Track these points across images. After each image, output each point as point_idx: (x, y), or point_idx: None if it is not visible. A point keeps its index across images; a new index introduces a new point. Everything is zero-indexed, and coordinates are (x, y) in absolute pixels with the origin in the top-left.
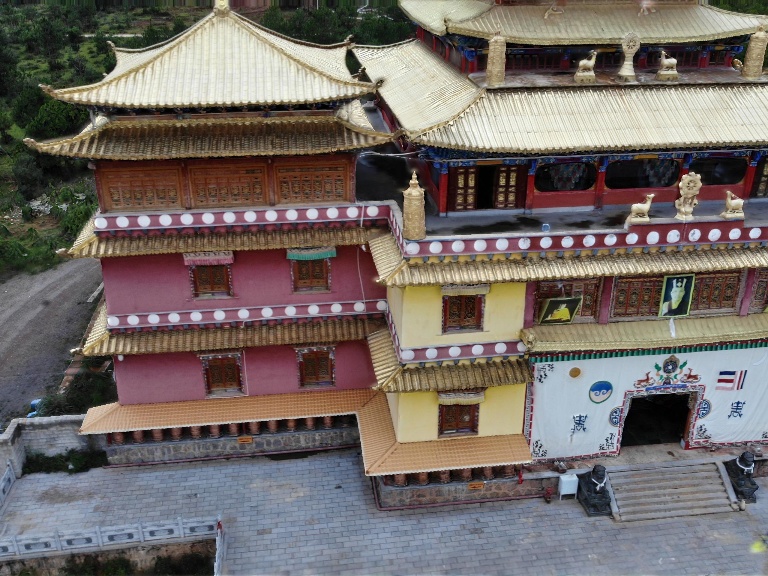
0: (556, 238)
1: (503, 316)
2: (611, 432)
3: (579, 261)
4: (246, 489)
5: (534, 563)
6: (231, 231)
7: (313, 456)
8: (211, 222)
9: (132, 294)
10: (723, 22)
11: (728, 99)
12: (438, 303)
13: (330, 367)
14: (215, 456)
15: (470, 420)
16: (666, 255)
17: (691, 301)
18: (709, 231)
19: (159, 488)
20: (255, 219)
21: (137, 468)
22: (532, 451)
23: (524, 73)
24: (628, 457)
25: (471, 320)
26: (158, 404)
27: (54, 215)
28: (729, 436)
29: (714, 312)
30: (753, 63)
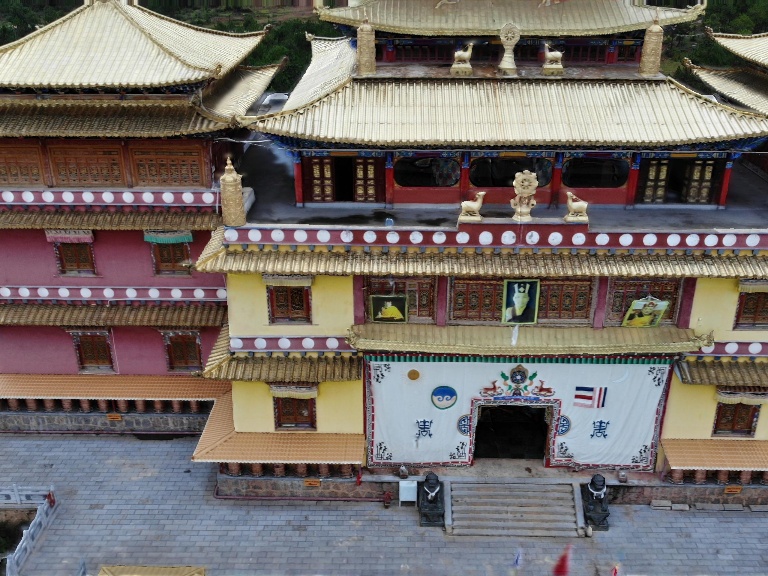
0: (380, 233)
1: (332, 310)
2: (461, 441)
3: (404, 258)
4: (100, 464)
5: (342, 566)
6: (90, 211)
7: (178, 439)
8: (71, 201)
9: (2, 267)
10: (628, 15)
11: (612, 96)
12: (262, 292)
13: (198, 352)
14: (87, 430)
15: (309, 415)
16: (500, 257)
17: (538, 308)
18: (549, 234)
19: (22, 456)
20: (113, 200)
21: (12, 435)
22: (376, 453)
23: (412, 64)
24: (481, 469)
25: (300, 312)
26: (34, 375)
27: None
28: (593, 457)
29: (565, 322)
30: (647, 58)
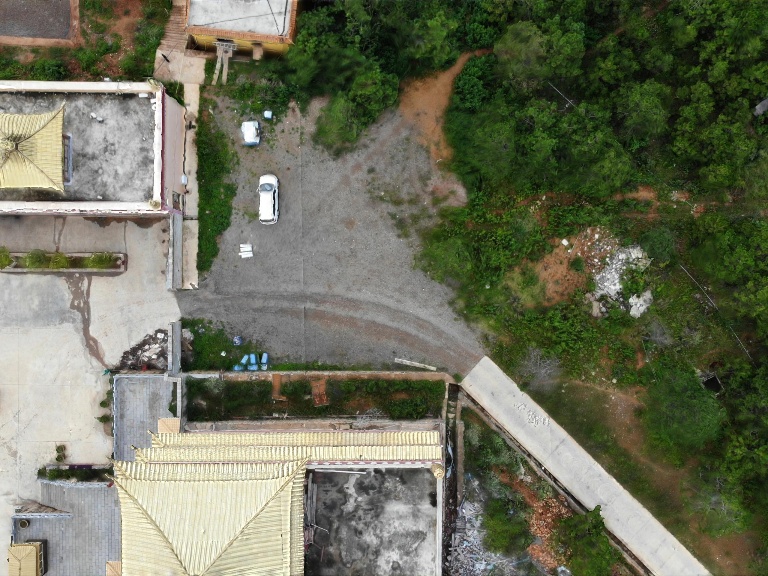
0: None
1: None
2: None
3: None
4: None
5: None
6: None
7: None
8: None
9: None
10: None
11: None
12: None
13: None
14: None
15: None
16: None
17: None
18: None
19: None
20: None
21: None
22: None
23: None
24: None
25: None
26: None
27: (585, 286)
28: None
29: None
30: None
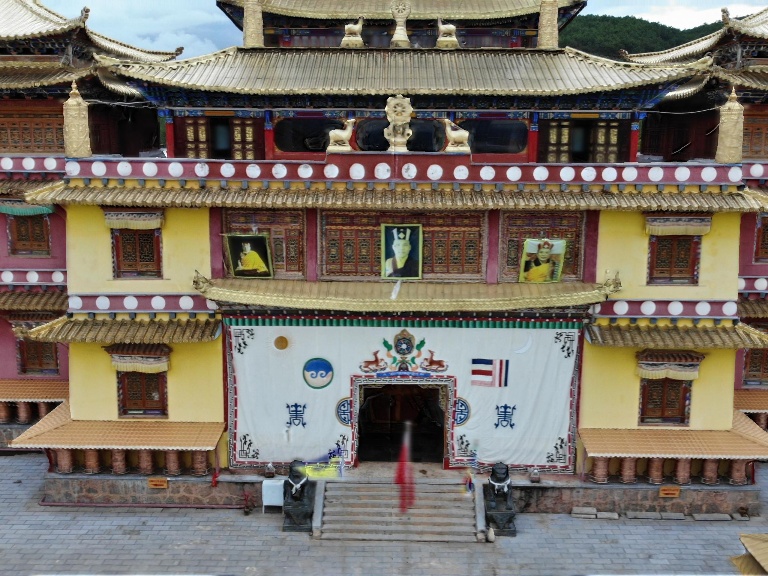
0: (239, 165)
1: (186, 261)
2: (342, 434)
3: (264, 192)
4: None
5: (170, 568)
6: None
7: (20, 455)
8: None
9: None
10: (527, 2)
11: (507, 61)
12: (106, 239)
13: (54, 351)
14: None
15: (160, 399)
16: (373, 192)
17: (422, 260)
18: (427, 167)
19: None
20: None
21: None
22: (240, 449)
23: None
24: (365, 470)
25: (150, 265)
26: None
27: None
28: (500, 454)
29: (454, 277)
30: (544, 30)
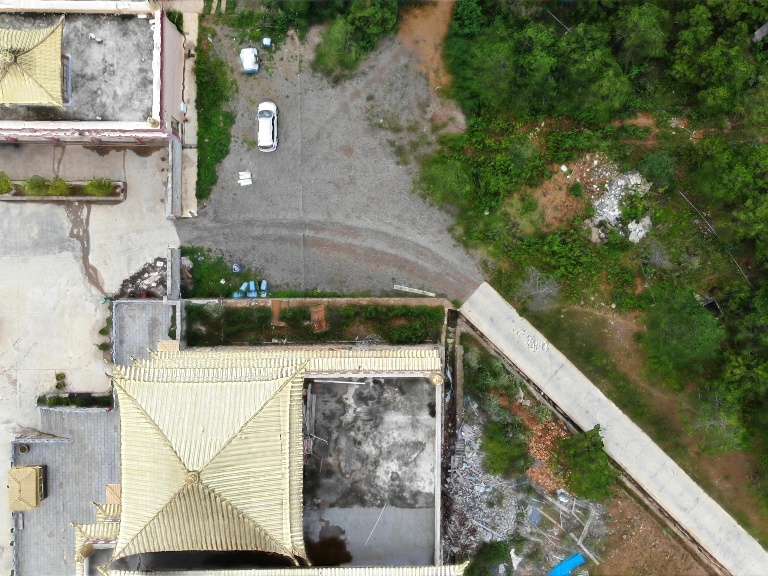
0: None
1: None
2: None
3: None
4: None
5: None
6: None
7: None
8: None
9: None
10: None
11: None
12: None
13: None
14: None
15: None
16: None
17: None
18: None
19: None
20: None
21: None
22: None
23: None
24: None
25: None
26: None
27: (584, 212)
28: None
29: None
30: None
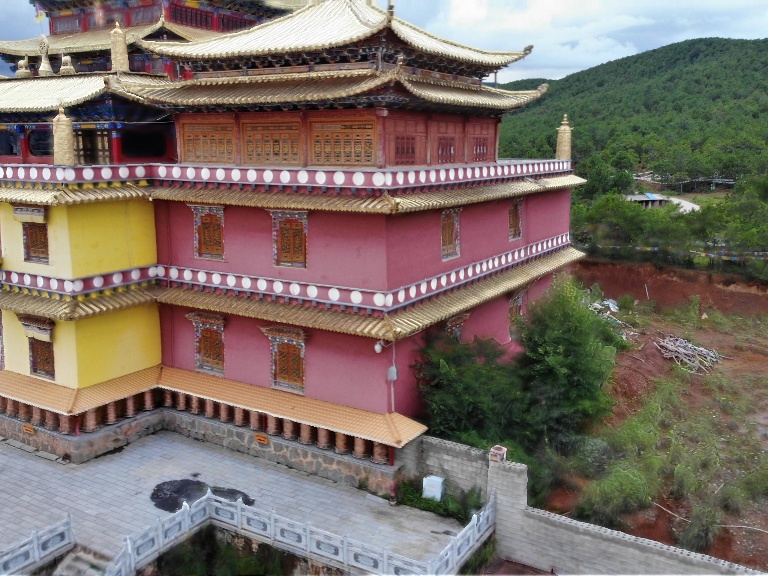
0: None
1: None
2: None
3: None
4: None
5: None
6: None
7: None
8: None
9: None
10: None
11: (72, 84)
12: None
13: None
14: None
15: None
16: None
17: None
18: None
19: None
20: None
21: None
22: None
23: None
24: None
25: None
26: None
27: None
28: None
29: None
30: None
